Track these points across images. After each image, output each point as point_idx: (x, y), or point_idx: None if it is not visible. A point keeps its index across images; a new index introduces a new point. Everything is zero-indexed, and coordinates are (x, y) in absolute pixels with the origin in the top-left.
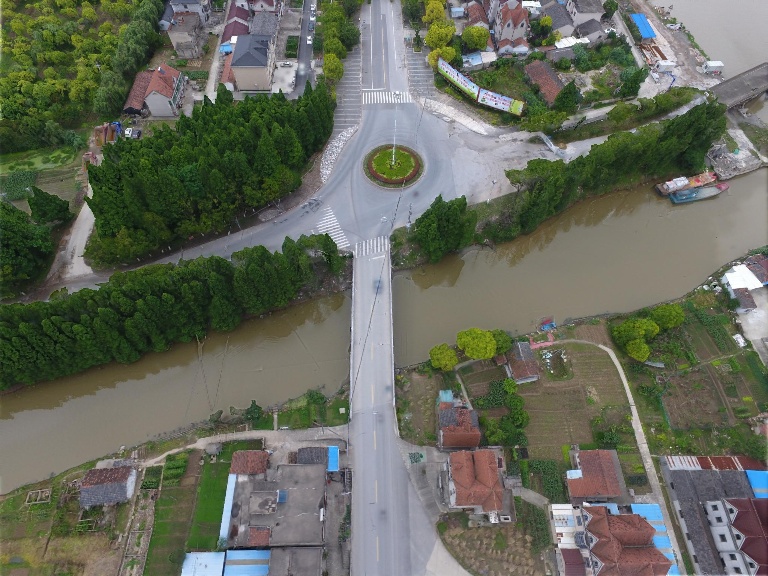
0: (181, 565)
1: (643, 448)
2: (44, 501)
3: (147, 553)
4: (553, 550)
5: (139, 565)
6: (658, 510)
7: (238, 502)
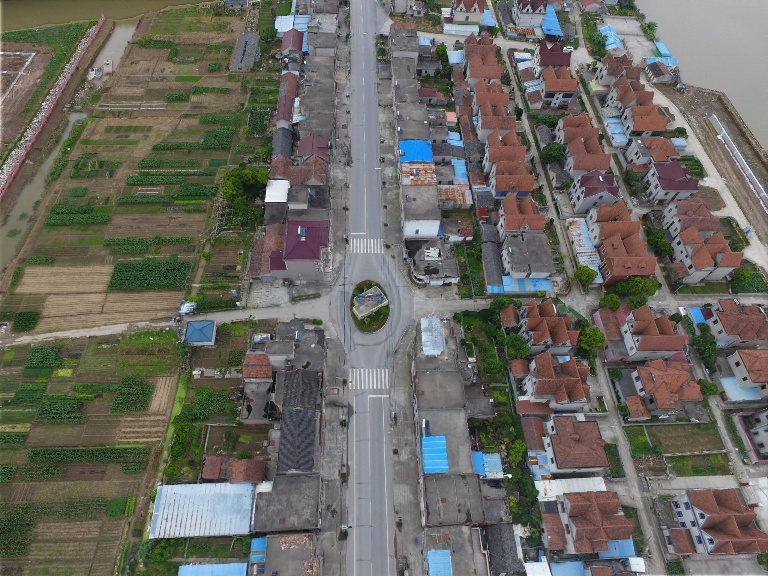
0: (275, 18)
1: (489, 4)
2: (207, 7)
3: (258, 21)
4: (441, 25)
5: (255, 24)
6: (490, 11)
7: (298, 5)
